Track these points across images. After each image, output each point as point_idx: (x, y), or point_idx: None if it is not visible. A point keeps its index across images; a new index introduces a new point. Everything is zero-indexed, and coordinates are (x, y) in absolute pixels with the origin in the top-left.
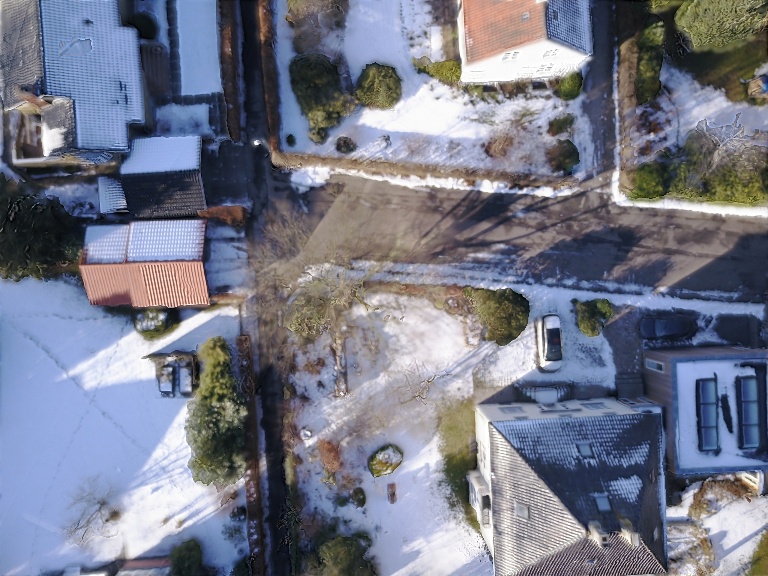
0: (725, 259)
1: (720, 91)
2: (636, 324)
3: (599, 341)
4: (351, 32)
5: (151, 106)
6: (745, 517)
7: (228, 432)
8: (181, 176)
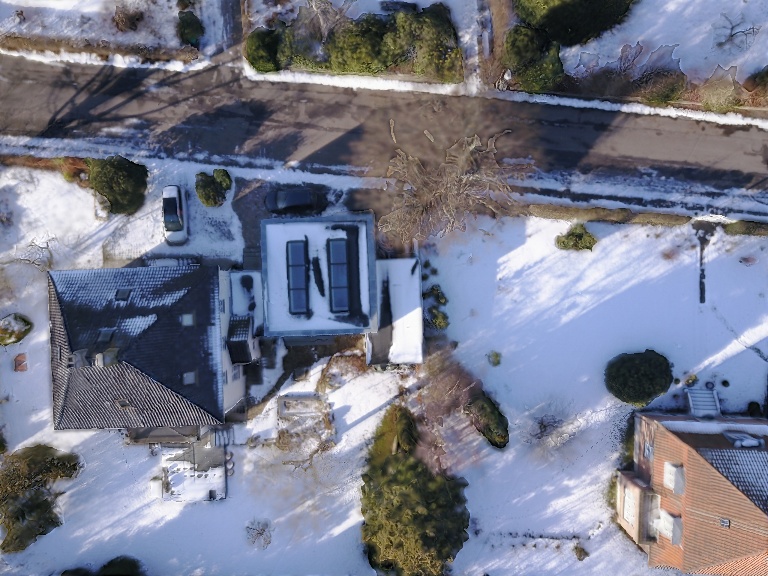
0: (356, 133)
1: None
2: (264, 198)
3: (228, 215)
4: None
5: None
6: (369, 392)
7: None
8: None
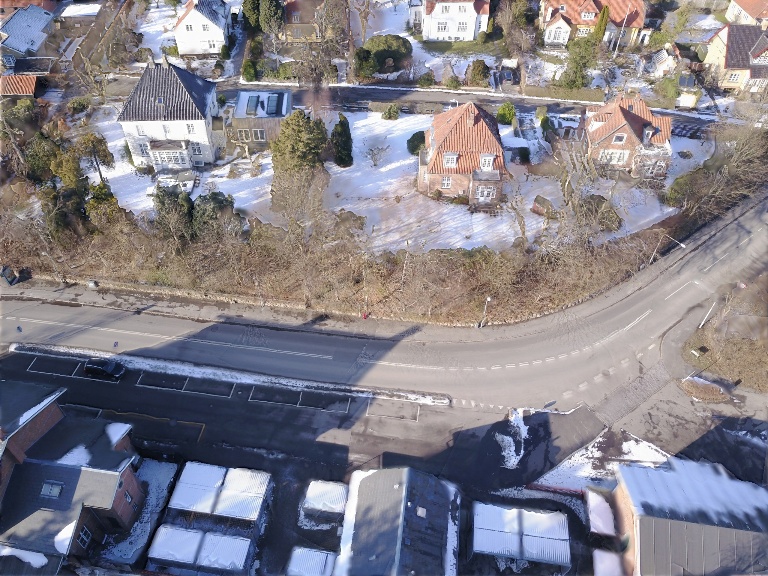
0: None
1: (291, 58)
2: None
3: None
4: None
5: None
6: None
7: (16, 119)
8: (42, 60)
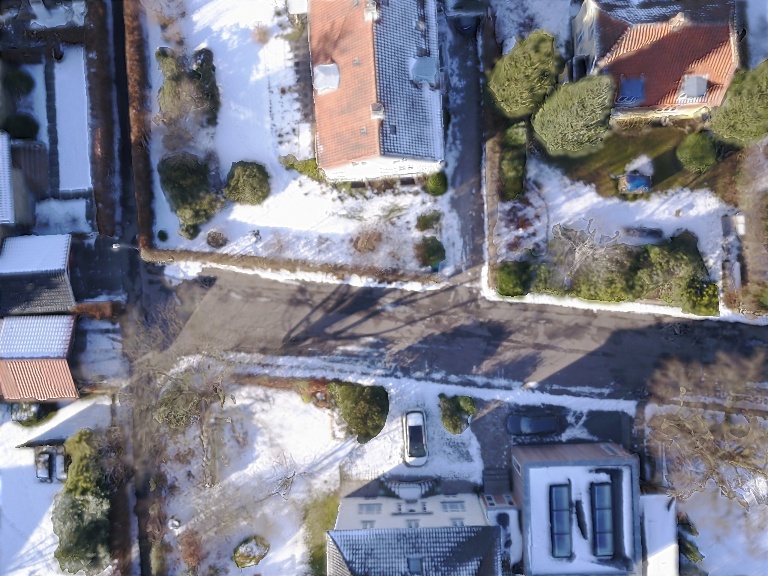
0: (596, 355)
1: (590, 187)
2: (504, 420)
3: (467, 436)
4: (222, 129)
5: (30, 201)
6: None
7: (92, 524)
8: (47, 275)
